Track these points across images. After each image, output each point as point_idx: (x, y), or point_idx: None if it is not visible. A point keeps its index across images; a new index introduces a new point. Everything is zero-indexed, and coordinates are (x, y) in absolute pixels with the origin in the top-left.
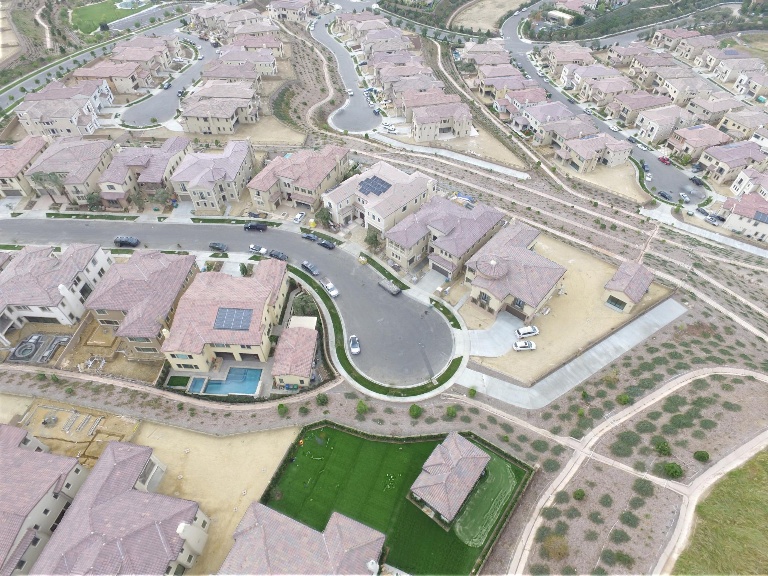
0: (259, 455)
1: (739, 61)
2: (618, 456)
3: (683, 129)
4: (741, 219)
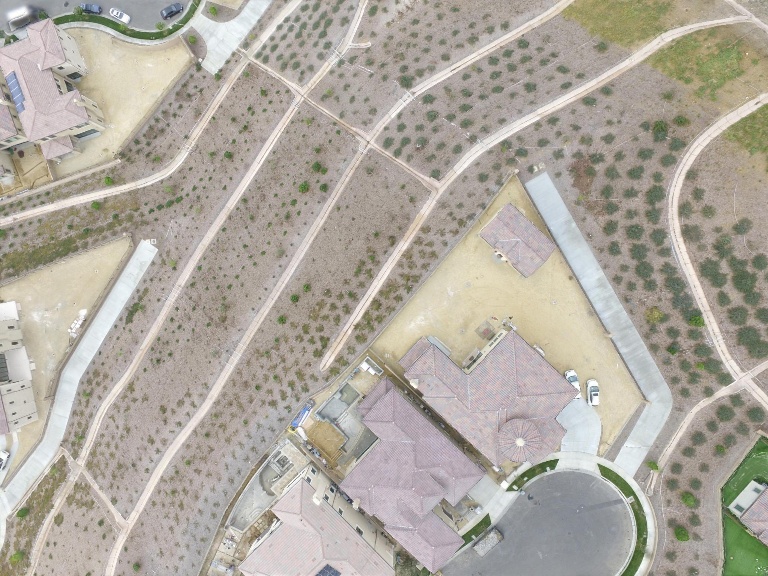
0: None
1: None
2: (767, 356)
3: None
4: None
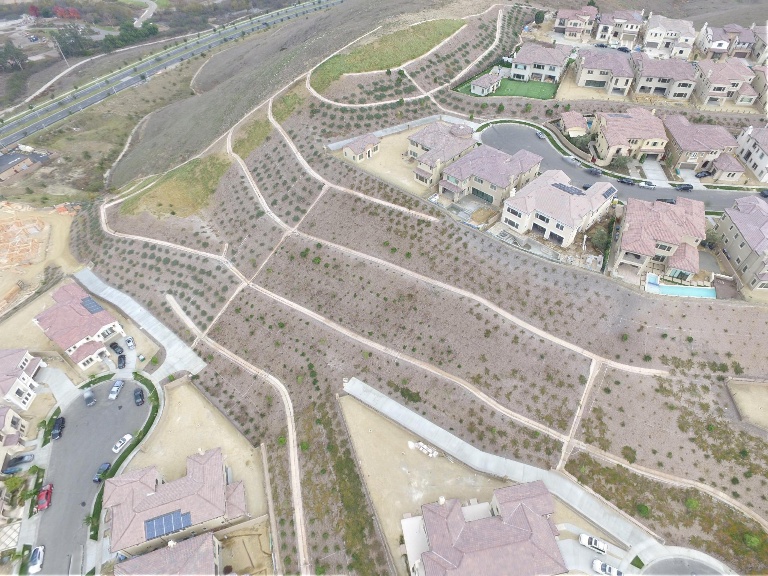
0: (570, 97)
1: None
2: None
3: None
4: None
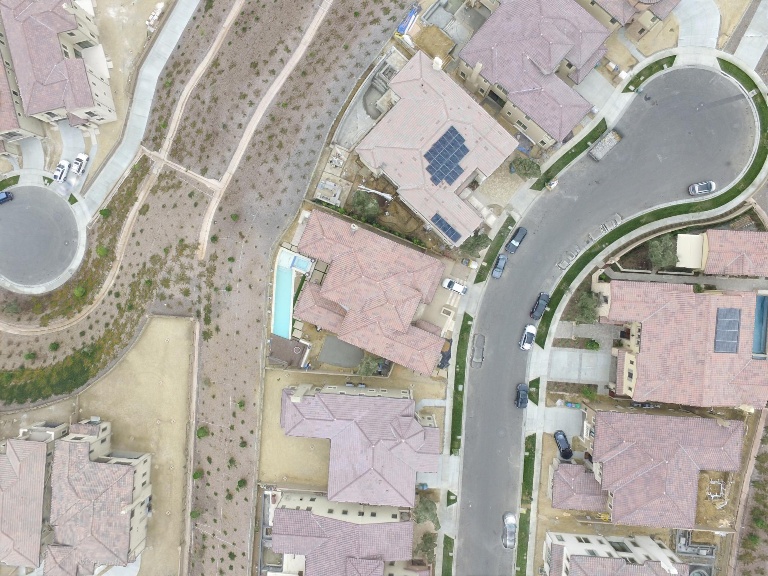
0: None
1: None
2: None
3: None
4: None
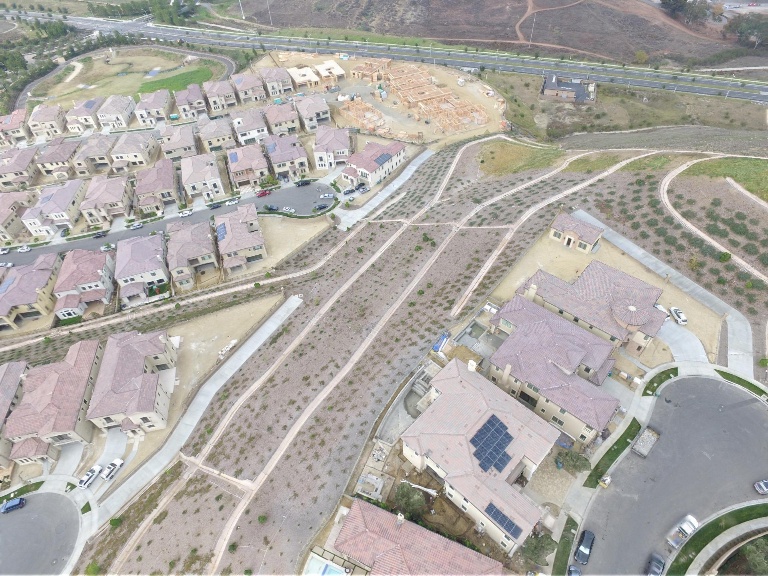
0: None
1: (111, 105)
2: None
3: (232, 165)
4: (376, 172)
